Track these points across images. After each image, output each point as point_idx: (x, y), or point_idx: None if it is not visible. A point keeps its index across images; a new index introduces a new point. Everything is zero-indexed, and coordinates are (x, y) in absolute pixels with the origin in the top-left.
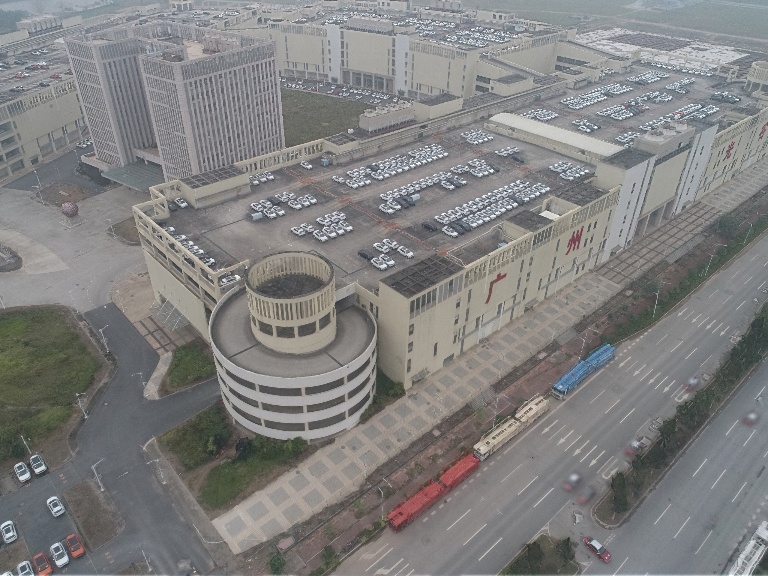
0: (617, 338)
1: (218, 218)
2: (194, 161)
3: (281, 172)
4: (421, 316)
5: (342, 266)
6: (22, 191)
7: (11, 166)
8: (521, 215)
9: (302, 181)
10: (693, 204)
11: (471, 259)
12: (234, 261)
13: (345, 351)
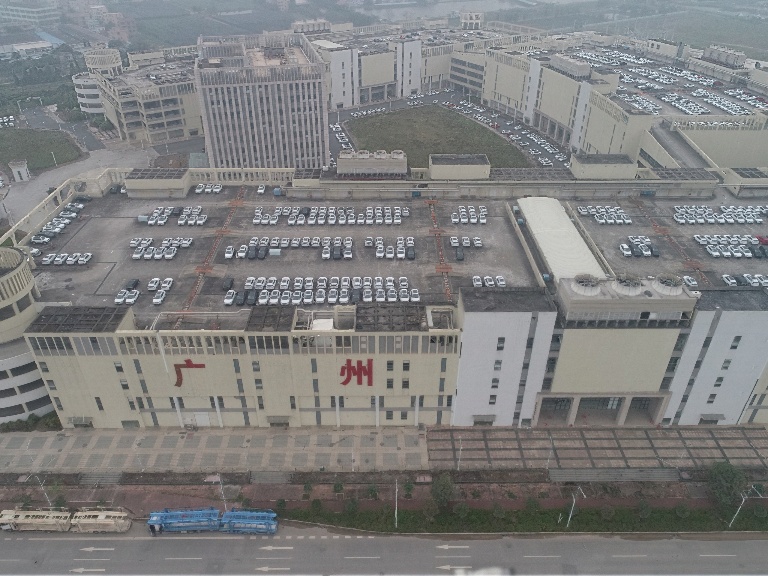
0: (313, 517)
1: (124, 210)
2: (210, 160)
3: (236, 189)
4: (55, 358)
5: (104, 286)
6: (156, 153)
7: (171, 132)
8: (278, 309)
9: (232, 202)
10: (741, 425)
11: None
12: (60, 247)
13: None
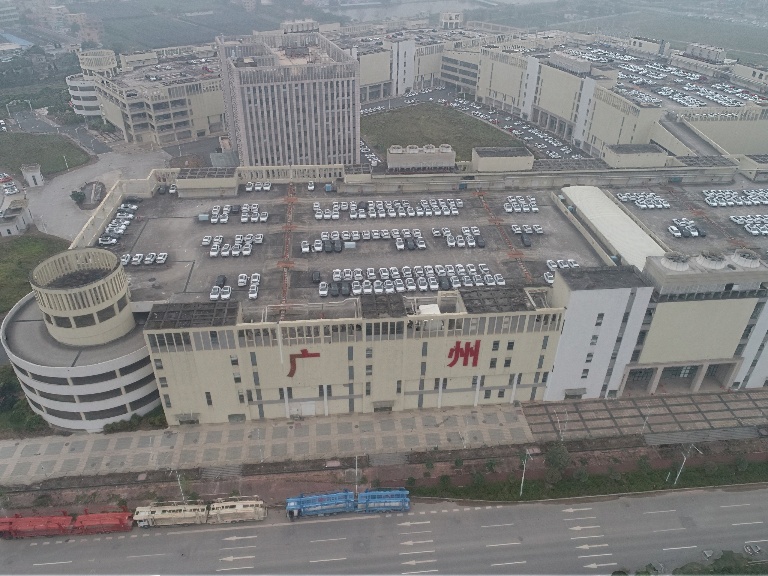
0: (440, 492)
1: (180, 210)
2: (245, 159)
3: (285, 186)
4: (171, 355)
5: (191, 283)
6: (168, 154)
7: (179, 134)
8: (386, 297)
9: (286, 199)
10: None
11: None
12: (130, 248)
13: (95, 357)
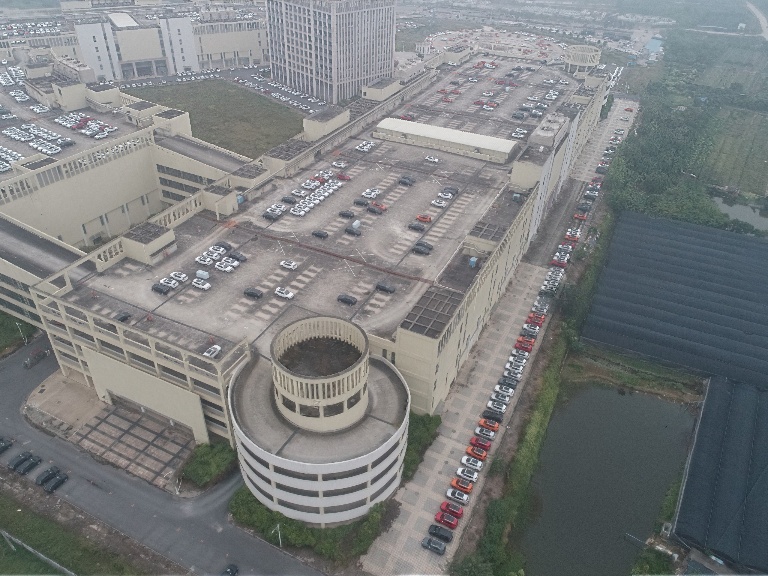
0: None
1: None
2: None
3: None
4: None
5: None
6: None
7: None
8: (215, 0)
9: None
10: None
11: (241, 7)
12: None
13: None
